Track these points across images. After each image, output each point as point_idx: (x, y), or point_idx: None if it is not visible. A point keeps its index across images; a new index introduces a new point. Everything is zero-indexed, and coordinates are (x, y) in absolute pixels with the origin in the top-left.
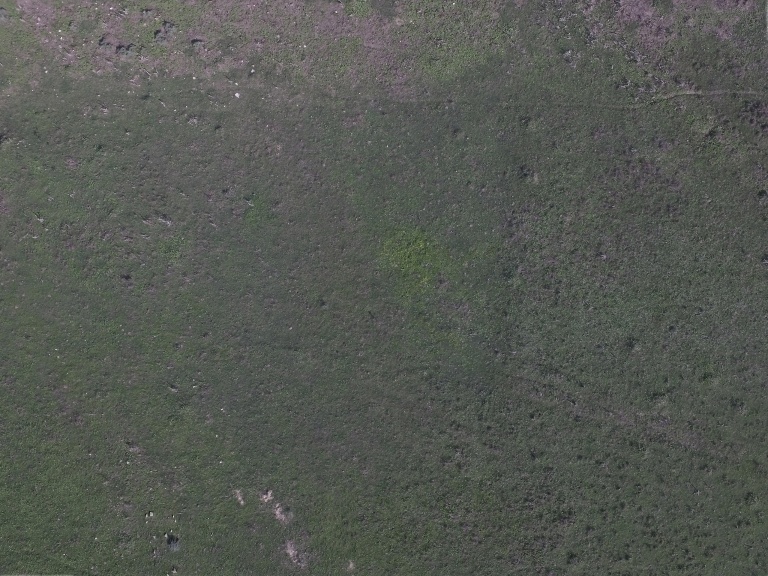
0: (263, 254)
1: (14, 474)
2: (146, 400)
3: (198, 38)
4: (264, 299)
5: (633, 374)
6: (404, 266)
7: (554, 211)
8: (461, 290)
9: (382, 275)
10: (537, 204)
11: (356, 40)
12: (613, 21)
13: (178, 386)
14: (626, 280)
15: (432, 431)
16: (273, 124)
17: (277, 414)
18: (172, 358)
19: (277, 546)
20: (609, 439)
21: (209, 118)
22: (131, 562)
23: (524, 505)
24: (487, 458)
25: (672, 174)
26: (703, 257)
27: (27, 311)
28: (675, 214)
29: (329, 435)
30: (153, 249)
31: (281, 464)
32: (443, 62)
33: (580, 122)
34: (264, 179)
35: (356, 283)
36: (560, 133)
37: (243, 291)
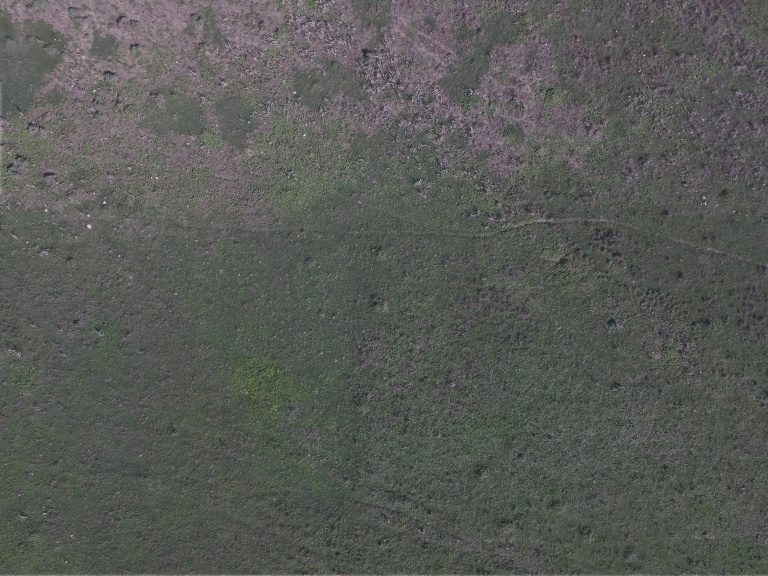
0: (114, 383)
1: None
2: None
3: (50, 171)
4: (114, 427)
5: (481, 501)
6: (255, 393)
7: (404, 339)
8: (311, 417)
9: (233, 402)
10: (387, 332)
11: (207, 171)
12: (464, 150)
13: (28, 513)
14: (475, 407)
15: (281, 557)
16: (125, 254)
17: (127, 540)
18: (23, 486)
19: None
20: (456, 566)
21: (61, 249)
22: None
23: None
24: None
25: (523, 301)
26: (552, 385)
27: None
28: (525, 342)
29: (178, 561)
30: (4, 379)
31: None
32: (293, 192)
33: (431, 250)
34: (115, 309)
35: (206, 410)
36: (411, 261)
37: (93, 419)
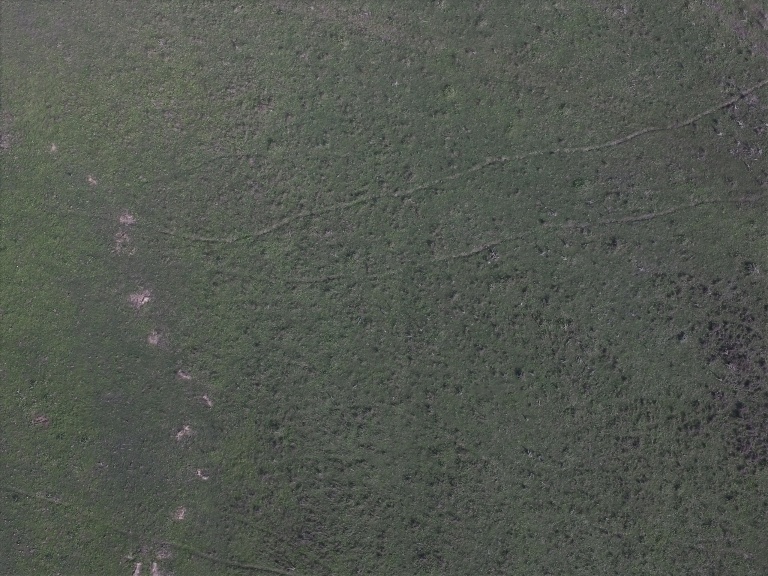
0: None
1: None
2: None
3: None
4: None
5: None
6: None
7: None
8: None
9: None
10: None
11: None
12: None
13: None
14: None
15: (136, 22)
16: None
17: None
18: None
19: None
20: (310, 32)
21: None
22: None
23: (226, 94)
24: (191, 50)
25: None
26: None
27: None
28: None
29: (33, 22)
30: None
31: None
32: None
33: None
34: None
35: None
36: None
37: None
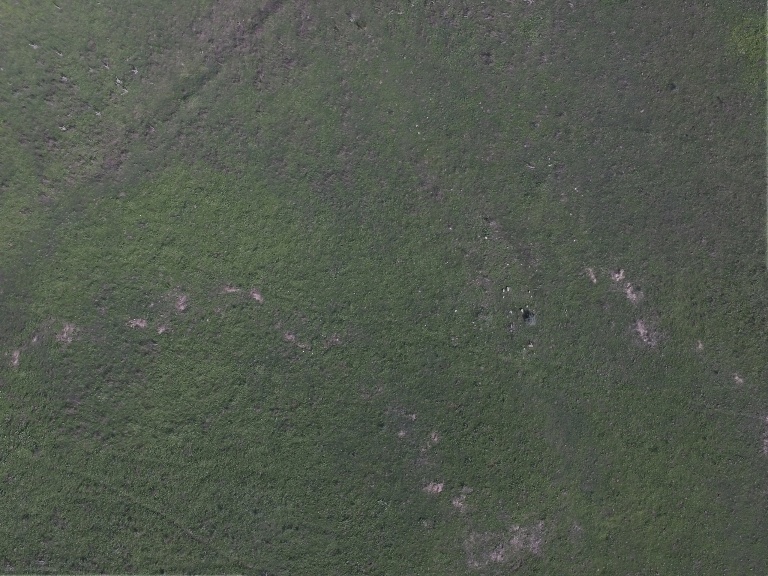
0: (617, 36)
1: (376, 246)
2: (503, 177)
3: None
4: (618, 81)
5: None
6: (752, 53)
7: None
8: None
9: (730, 61)
10: None
11: None
12: None
13: (534, 164)
14: None
15: None
16: None
17: (628, 195)
18: (529, 137)
19: (628, 325)
20: None
21: None
22: (490, 335)
23: None
24: None
25: None
26: None
27: (390, 87)
28: None
29: (678, 217)
30: (513, 28)
31: (632, 244)
32: None
33: None
34: None
35: (705, 68)
36: None
37: (598, 72)
